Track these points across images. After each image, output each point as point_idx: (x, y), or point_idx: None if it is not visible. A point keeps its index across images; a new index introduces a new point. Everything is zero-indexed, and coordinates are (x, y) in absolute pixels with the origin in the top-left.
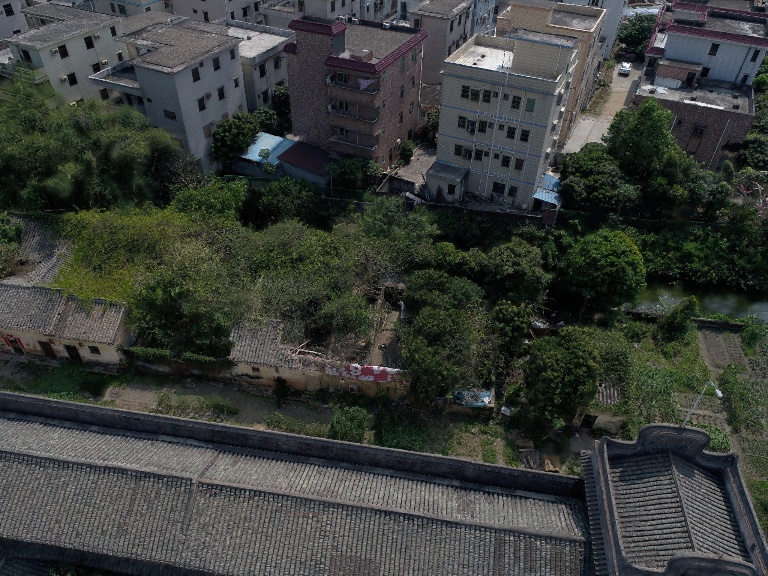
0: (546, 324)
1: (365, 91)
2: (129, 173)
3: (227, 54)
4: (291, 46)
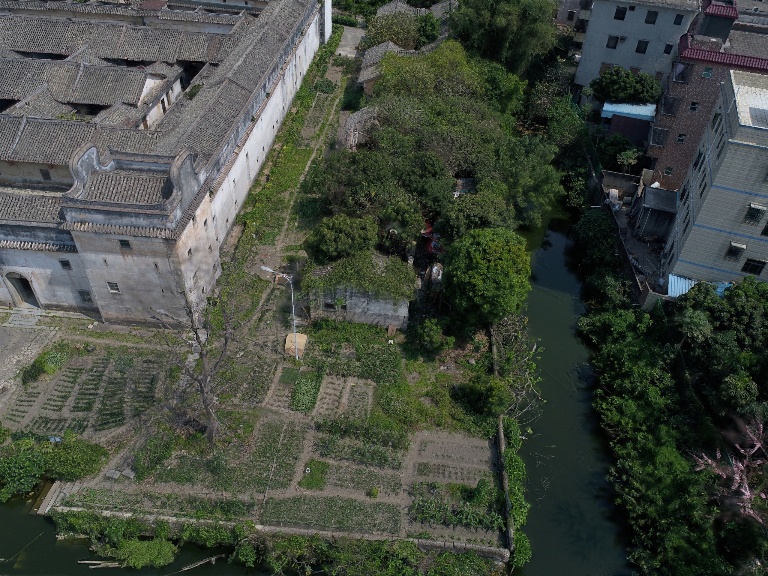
0: (438, 276)
1: (676, 77)
2: (501, 42)
3: (671, 16)
4: (697, 21)
